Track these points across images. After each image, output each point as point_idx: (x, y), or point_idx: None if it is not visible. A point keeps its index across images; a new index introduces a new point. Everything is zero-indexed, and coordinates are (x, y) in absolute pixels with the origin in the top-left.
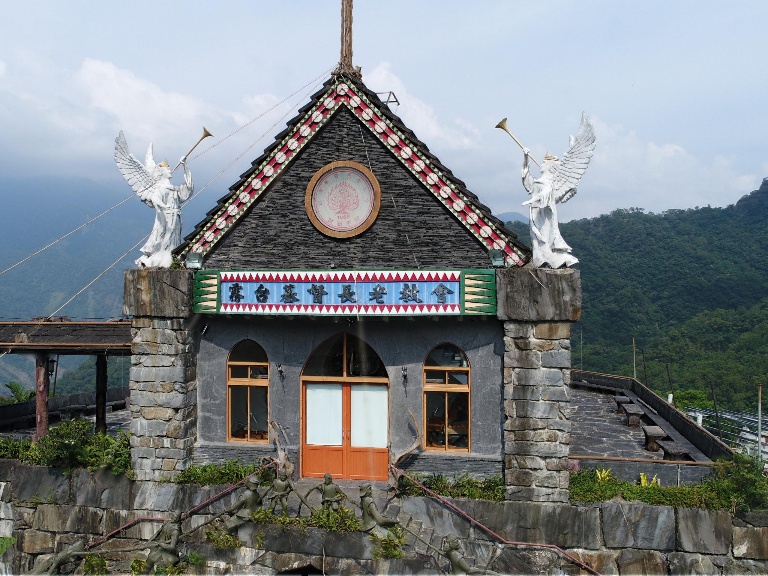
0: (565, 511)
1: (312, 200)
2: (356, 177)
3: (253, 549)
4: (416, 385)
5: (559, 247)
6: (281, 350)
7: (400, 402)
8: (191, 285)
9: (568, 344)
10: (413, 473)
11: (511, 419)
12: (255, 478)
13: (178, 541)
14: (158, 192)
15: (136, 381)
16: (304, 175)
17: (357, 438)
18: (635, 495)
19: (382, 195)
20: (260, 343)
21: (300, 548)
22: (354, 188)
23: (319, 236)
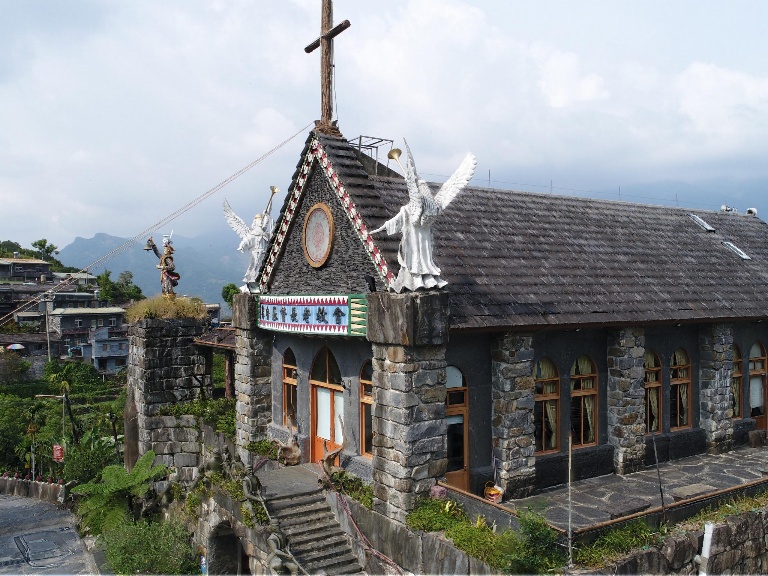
0: (402, 532)
1: (306, 237)
2: (323, 216)
3: (213, 500)
4: (355, 396)
5: (413, 271)
6: (301, 358)
7: (348, 409)
8: (253, 306)
9: (402, 368)
10: (349, 473)
11: (376, 435)
12: (216, 449)
13: (198, 485)
14: (246, 238)
15: (237, 373)
16: (304, 217)
17: (338, 436)
18: (453, 533)
19: (335, 230)
20: (293, 351)
21: (226, 506)
22: (322, 225)
23: (310, 266)
